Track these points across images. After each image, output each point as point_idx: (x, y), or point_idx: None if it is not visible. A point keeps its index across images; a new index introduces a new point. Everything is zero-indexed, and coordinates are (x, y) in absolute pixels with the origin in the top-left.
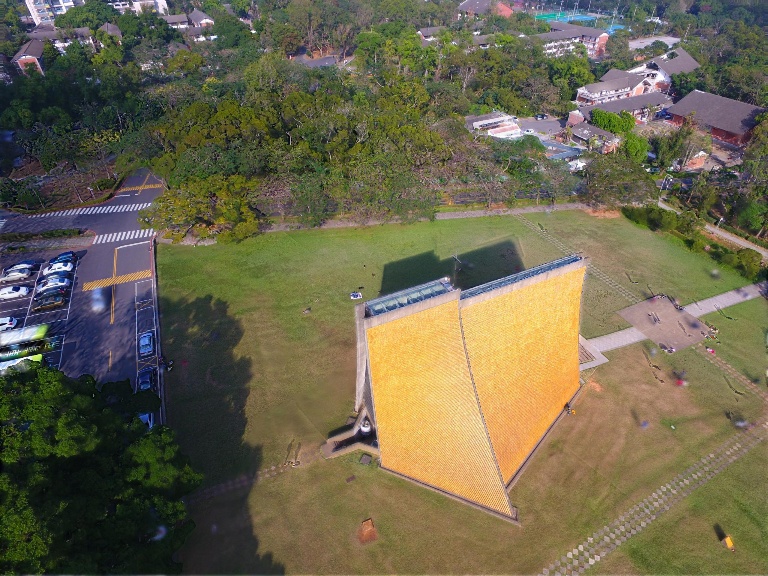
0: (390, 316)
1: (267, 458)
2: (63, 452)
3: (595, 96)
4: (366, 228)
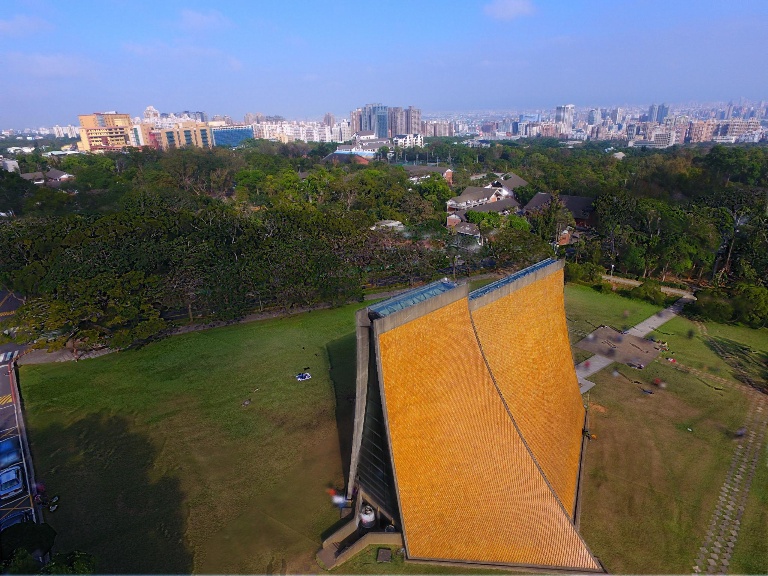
0: (403, 316)
1: None
2: None
3: (463, 205)
4: (292, 316)
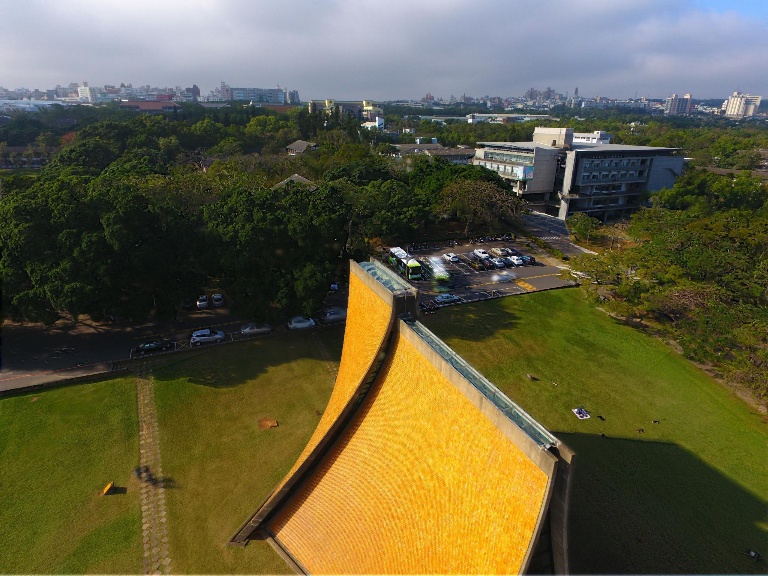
0: (359, 272)
1: None
2: None
3: None
4: None
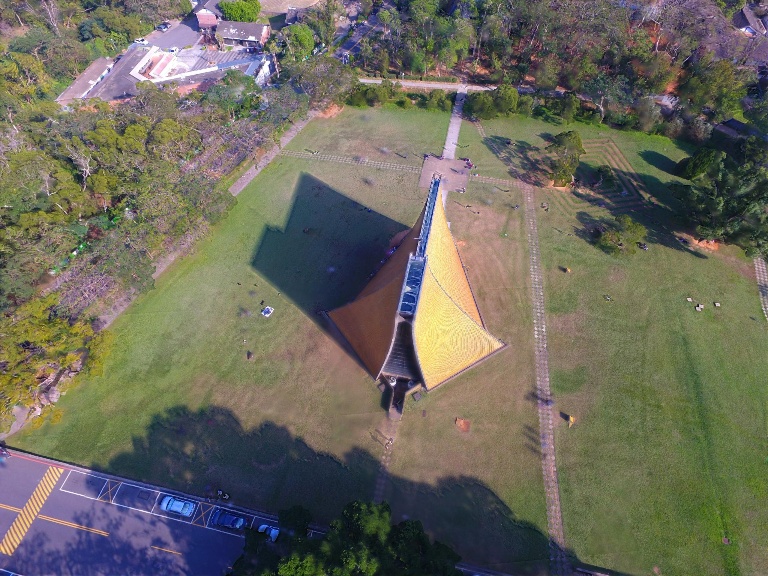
0: (418, 305)
1: (373, 458)
2: (374, 571)
3: None
4: None
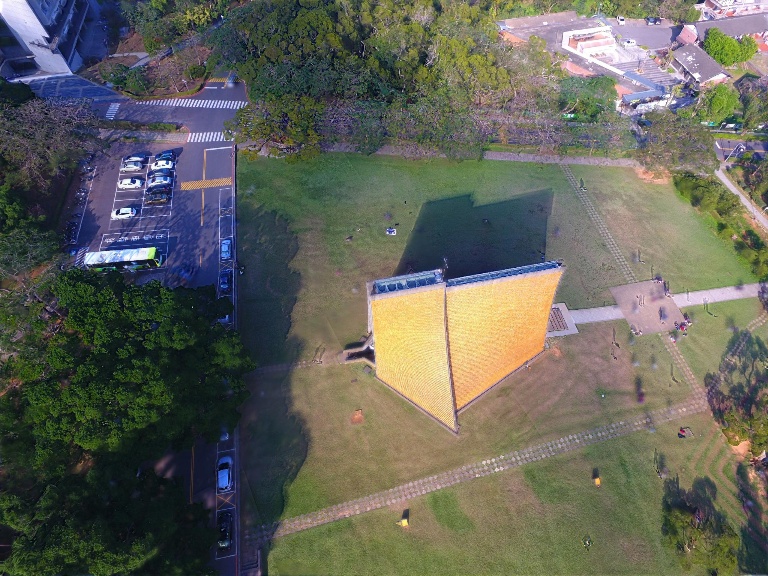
0: (389, 295)
1: (301, 354)
2: (177, 347)
3: (726, 3)
4: (417, 159)
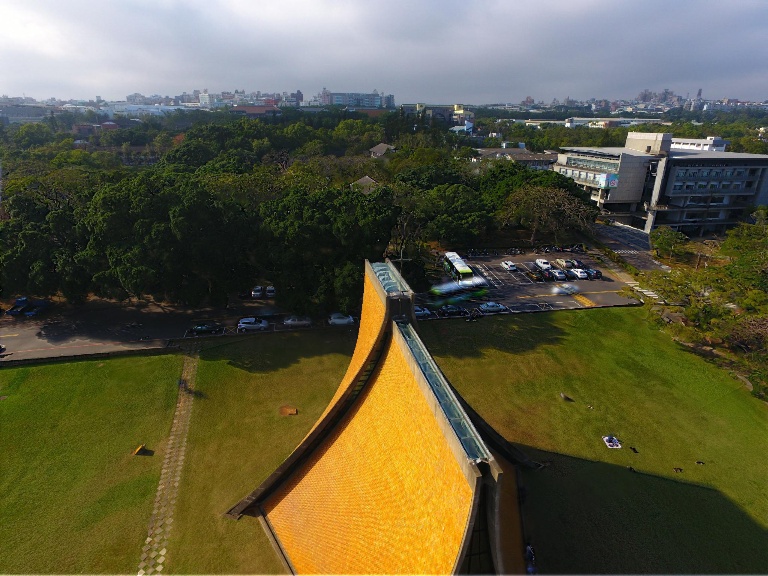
0: None
1: None
2: None
3: None
4: None
